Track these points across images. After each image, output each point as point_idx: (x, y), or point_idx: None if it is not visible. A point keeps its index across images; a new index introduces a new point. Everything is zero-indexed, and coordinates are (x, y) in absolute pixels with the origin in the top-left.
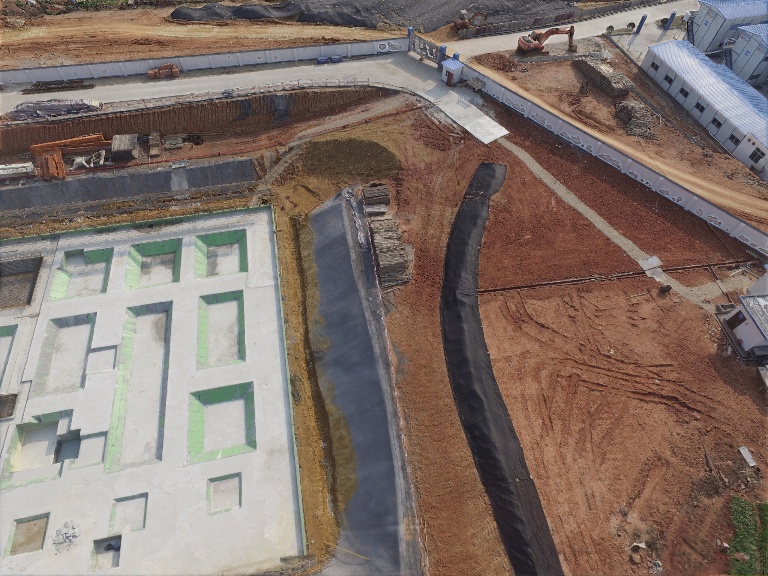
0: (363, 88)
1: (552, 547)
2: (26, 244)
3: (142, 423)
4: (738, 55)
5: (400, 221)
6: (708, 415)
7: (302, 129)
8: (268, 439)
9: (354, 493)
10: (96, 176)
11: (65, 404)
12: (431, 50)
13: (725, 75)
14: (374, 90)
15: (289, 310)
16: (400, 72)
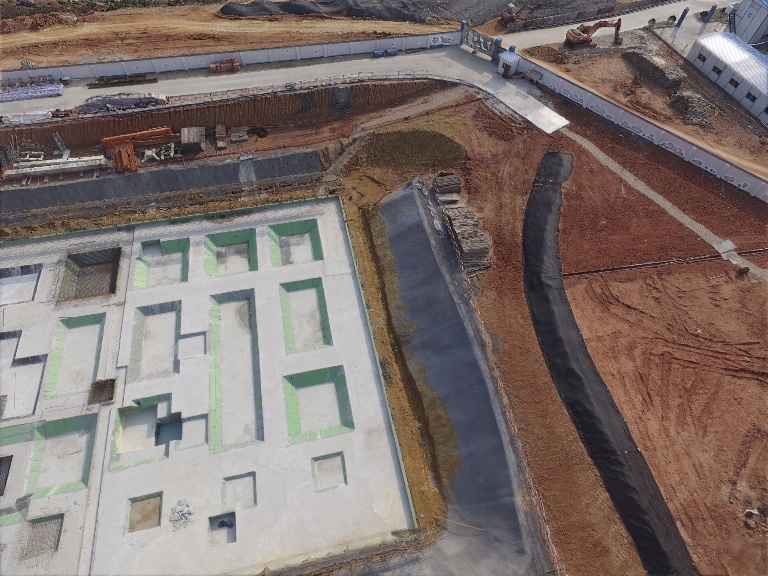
0: (422, 80)
1: (668, 514)
2: (103, 235)
3: (239, 406)
4: None
5: (473, 209)
6: None
7: (363, 121)
8: (365, 419)
9: (458, 469)
10: (167, 168)
11: (163, 388)
12: (485, 43)
13: None
14: (432, 82)
15: (370, 296)
16: (456, 65)
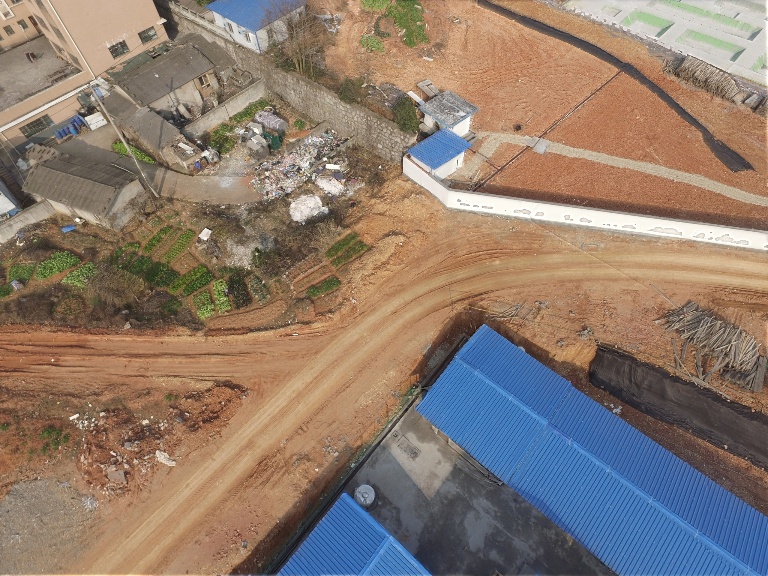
0: None
1: None
2: None
3: (673, 13)
4: None
5: (727, 104)
6: None
7: None
8: None
9: None
10: None
11: None
12: None
13: None
14: None
15: None
16: None
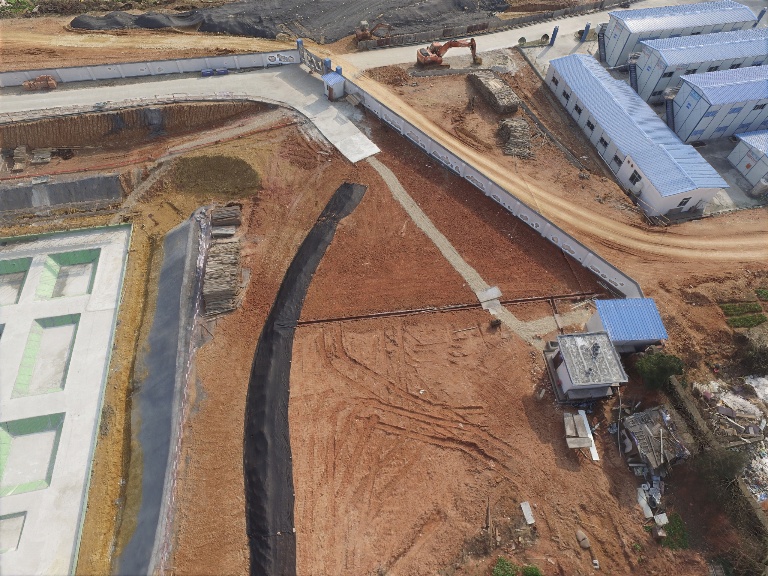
0: (241, 102)
1: None
2: None
3: None
4: (641, 70)
5: (246, 244)
6: (502, 464)
7: (175, 144)
8: (64, 475)
9: (131, 538)
10: None
11: None
12: (317, 63)
13: (621, 92)
14: (253, 104)
15: (121, 336)
16: (284, 86)
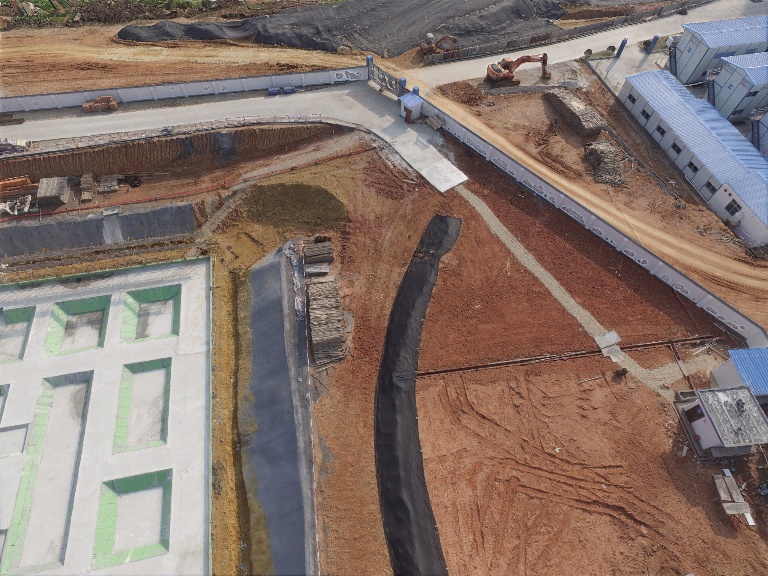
0: (315, 125)
1: None
2: None
3: (48, 517)
4: (721, 88)
5: (343, 283)
6: (656, 531)
7: (248, 170)
8: (182, 539)
9: None
10: (20, 225)
11: None
12: (390, 82)
13: (705, 112)
14: (327, 127)
15: (218, 383)
16: (356, 106)
